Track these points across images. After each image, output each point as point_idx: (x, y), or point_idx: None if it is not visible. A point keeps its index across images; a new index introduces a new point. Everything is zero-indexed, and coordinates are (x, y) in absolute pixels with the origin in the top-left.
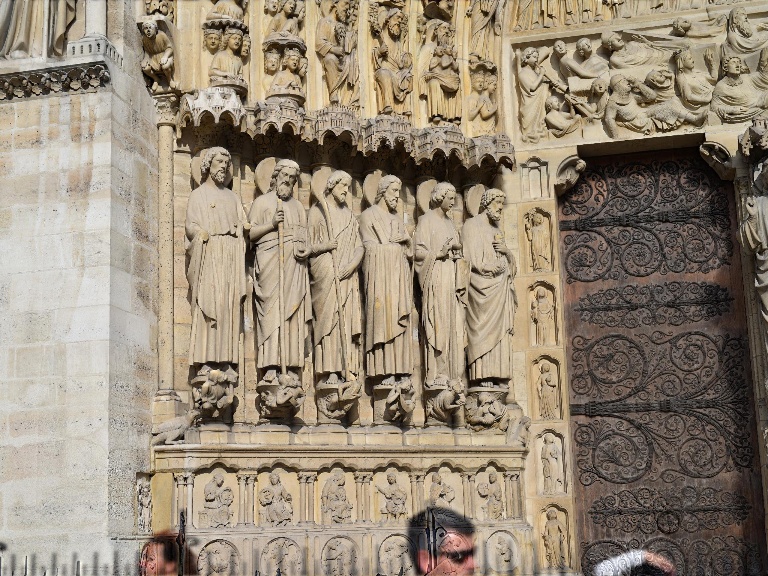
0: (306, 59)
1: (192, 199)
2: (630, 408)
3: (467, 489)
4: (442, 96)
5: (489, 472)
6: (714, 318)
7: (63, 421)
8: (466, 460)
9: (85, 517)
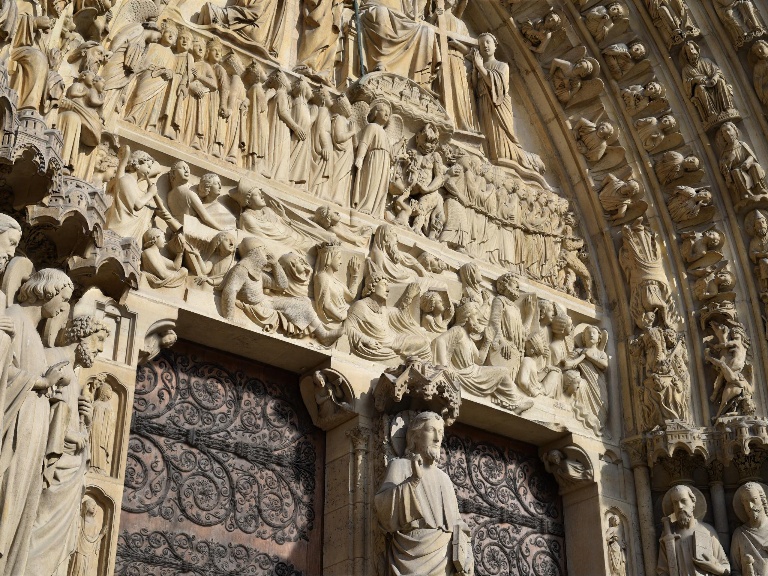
0: None
1: None
2: None
3: None
4: None
5: None
6: None
7: None
8: None
9: None
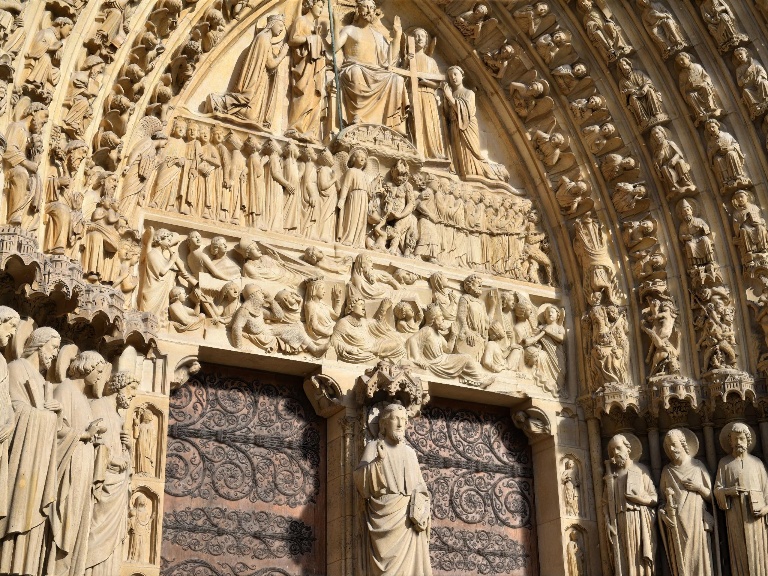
0: (1, 163)
1: None
2: None
3: None
4: (102, 253)
5: None
6: (296, 556)
7: None
8: None
9: None
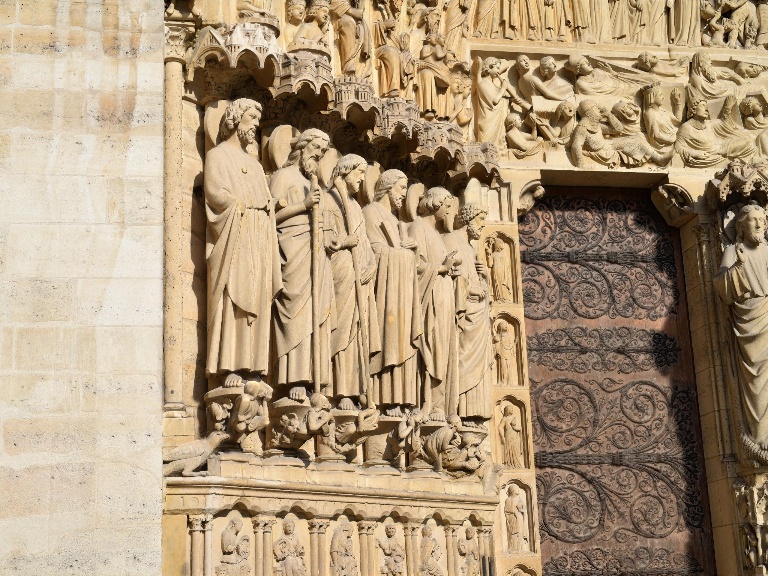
0: None
1: (216, 159)
2: (582, 460)
3: (451, 545)
4: (435, 90)
5: (466, 526)
6: (663, 368)
7: (91, 435)
8: (454, 511)
9: (126, 572)
